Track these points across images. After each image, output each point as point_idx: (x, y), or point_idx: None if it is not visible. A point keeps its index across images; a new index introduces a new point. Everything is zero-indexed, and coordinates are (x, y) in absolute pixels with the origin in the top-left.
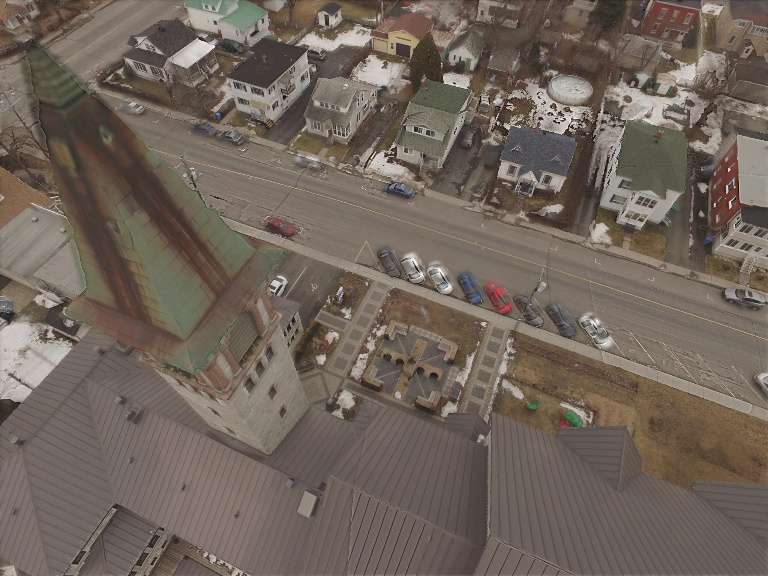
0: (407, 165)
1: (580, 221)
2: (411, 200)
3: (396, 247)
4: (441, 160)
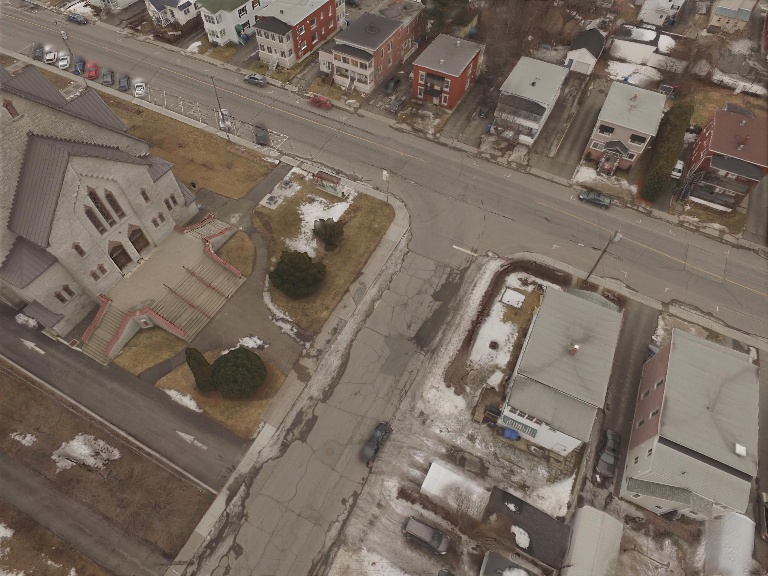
0: (95, 8)
1: (187, 41)
2: (83, 26)
3: (50, 47)
4: (117, 5)
